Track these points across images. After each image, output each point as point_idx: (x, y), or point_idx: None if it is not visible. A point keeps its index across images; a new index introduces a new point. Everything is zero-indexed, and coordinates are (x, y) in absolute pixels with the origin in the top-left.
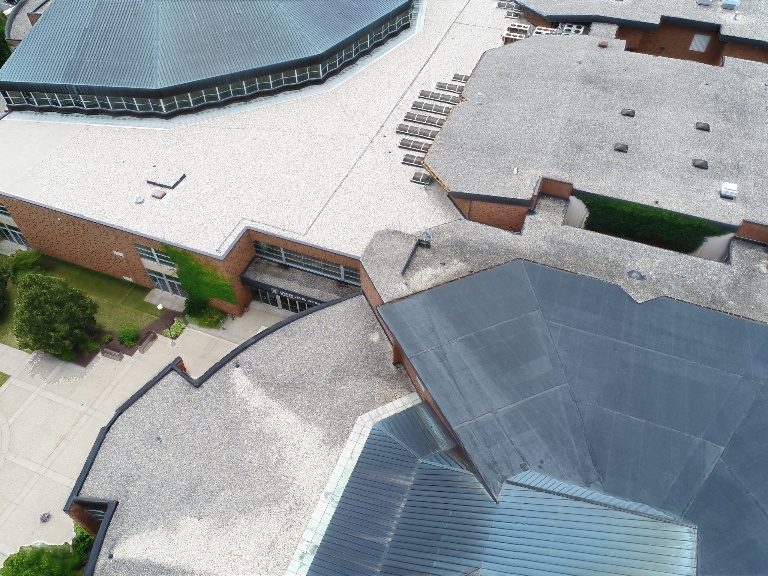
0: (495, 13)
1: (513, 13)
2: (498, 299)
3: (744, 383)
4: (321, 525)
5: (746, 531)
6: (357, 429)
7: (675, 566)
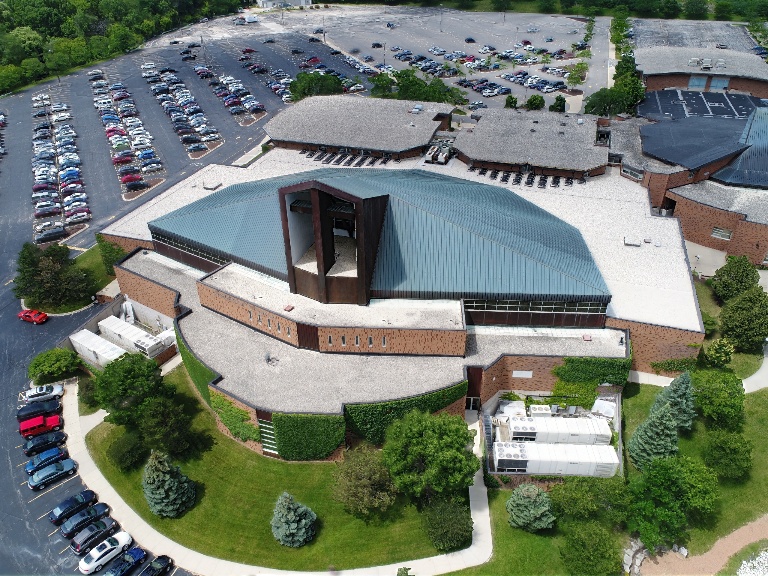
0: (392, 166)
1: (397, 160)
2: (670, 151)
3: (672, 127)
4: (767, 191)
5: (724, 127)
6: (729, 188)
7: (766, 110)
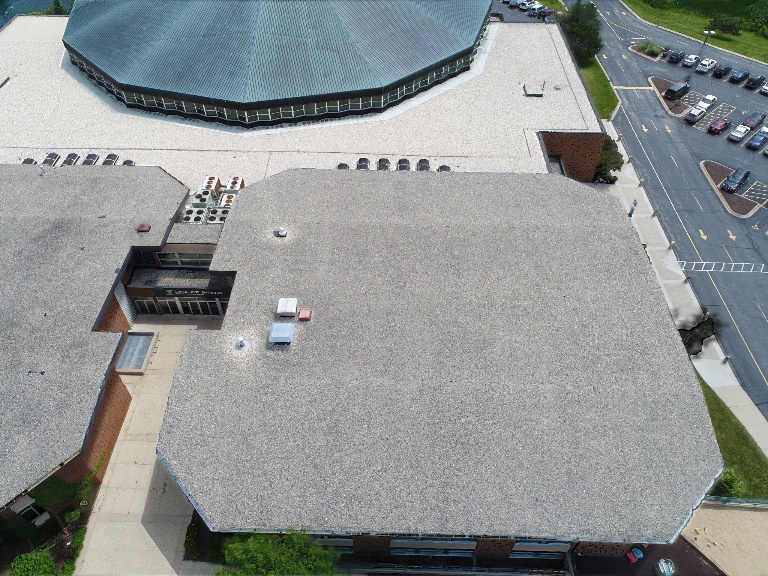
0: None
1: None
2: None
3: None
4: None
5: None
6: None
7: None
